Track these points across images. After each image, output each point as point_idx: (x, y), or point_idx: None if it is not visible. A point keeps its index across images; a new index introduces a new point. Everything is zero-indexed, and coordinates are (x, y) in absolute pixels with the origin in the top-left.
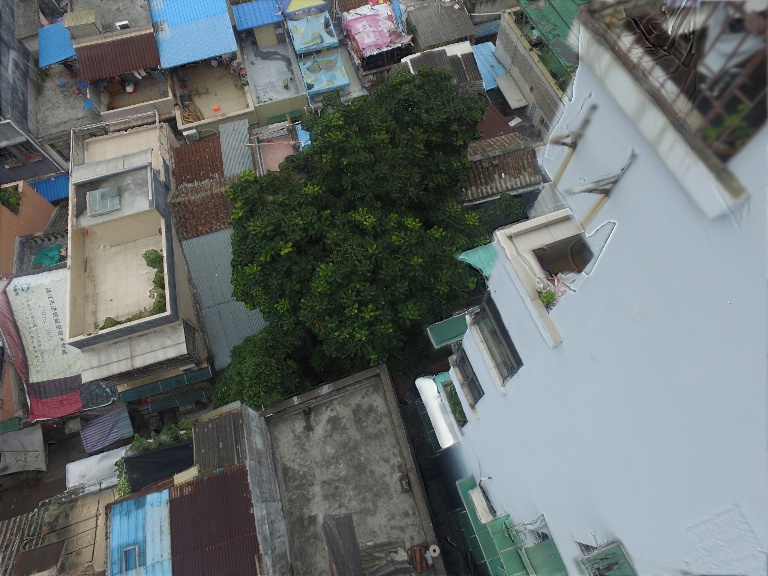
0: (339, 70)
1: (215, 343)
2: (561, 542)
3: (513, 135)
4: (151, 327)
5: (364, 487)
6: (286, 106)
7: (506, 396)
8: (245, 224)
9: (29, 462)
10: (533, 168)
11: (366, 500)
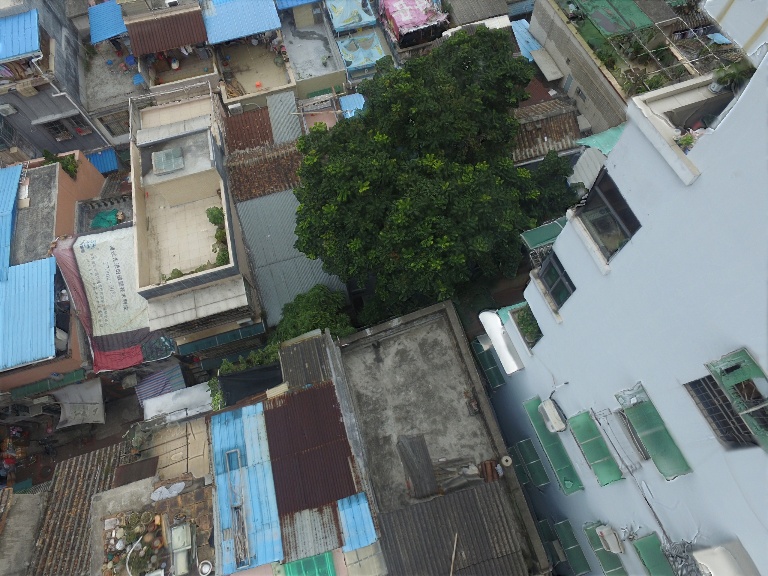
0: (376, 48)
1: (267, 301)
2: (661, 399)
3: (554, 102)
4: (214, 279)
5: (434, 411)
6: (326, 82)
7: (609, 274)
8: (322, 168)
9: (88, 416)
10: (574, 132)
11: (436, 422)
